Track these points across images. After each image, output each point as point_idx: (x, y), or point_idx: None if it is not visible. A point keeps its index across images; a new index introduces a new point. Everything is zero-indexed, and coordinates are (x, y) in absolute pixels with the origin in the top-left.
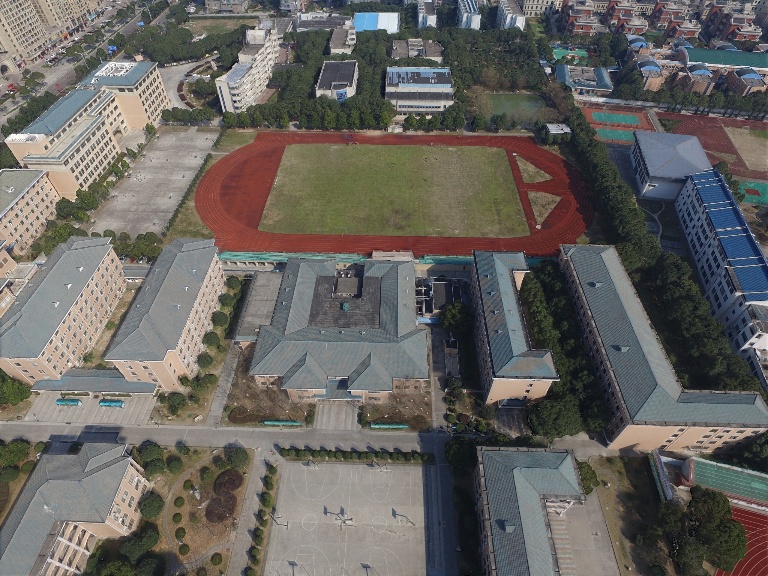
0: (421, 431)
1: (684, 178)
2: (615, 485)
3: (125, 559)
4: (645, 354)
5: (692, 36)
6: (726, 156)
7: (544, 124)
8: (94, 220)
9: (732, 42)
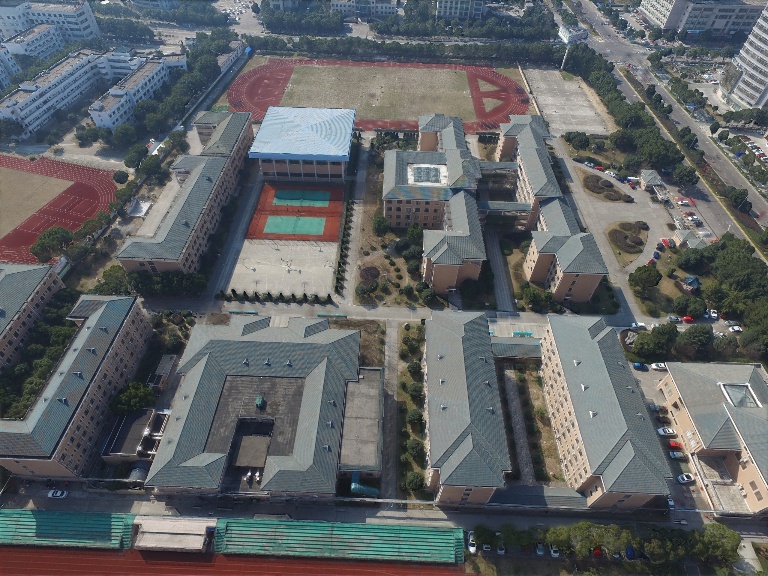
0: None
1: None
2: (93, 280)
3: (416, 244)
4: None
5: None
6: None
7: None
8: None
9: None
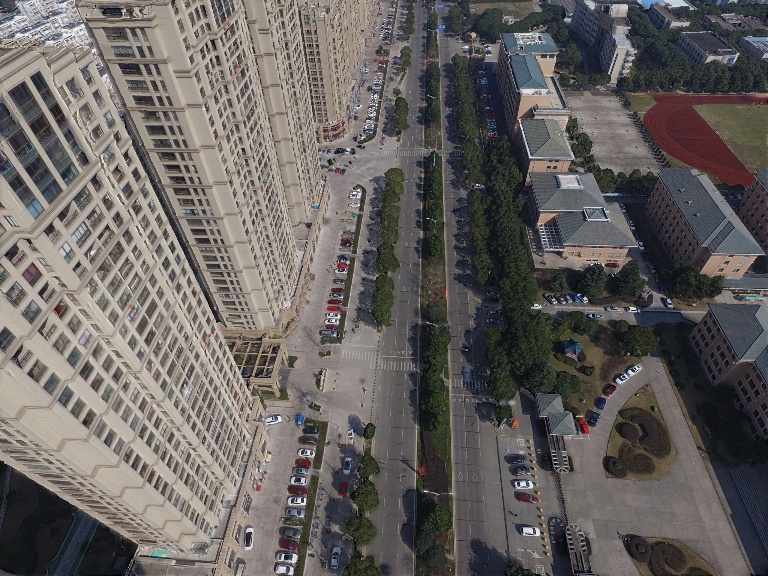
0: None
1: None
2: None
3: None
4: None
5: None
6: None
7: None
8: None
9: None
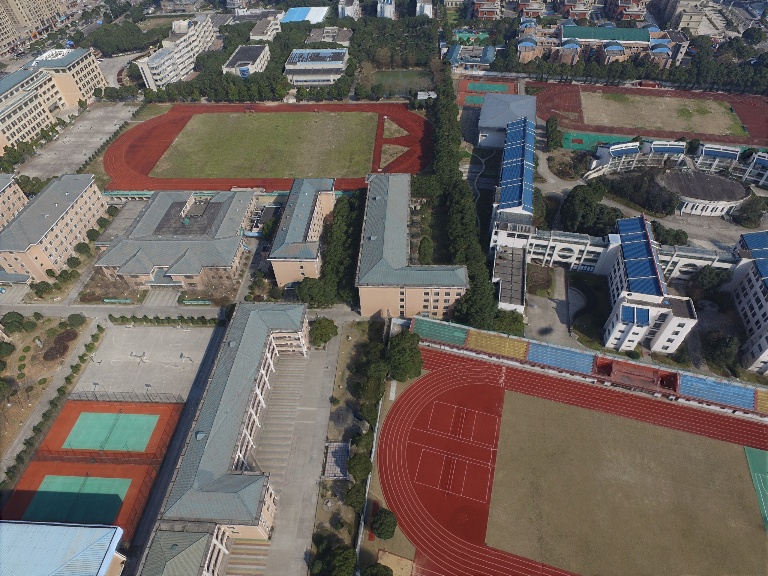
0: (223, 306)
1: (506, 127)
2: (356, 339)
3: None
4: (384, 240)
5: (583, 17)
6: (570, 114)
7: (416, 92)
8: (17, 170)
9: (619, 21)
